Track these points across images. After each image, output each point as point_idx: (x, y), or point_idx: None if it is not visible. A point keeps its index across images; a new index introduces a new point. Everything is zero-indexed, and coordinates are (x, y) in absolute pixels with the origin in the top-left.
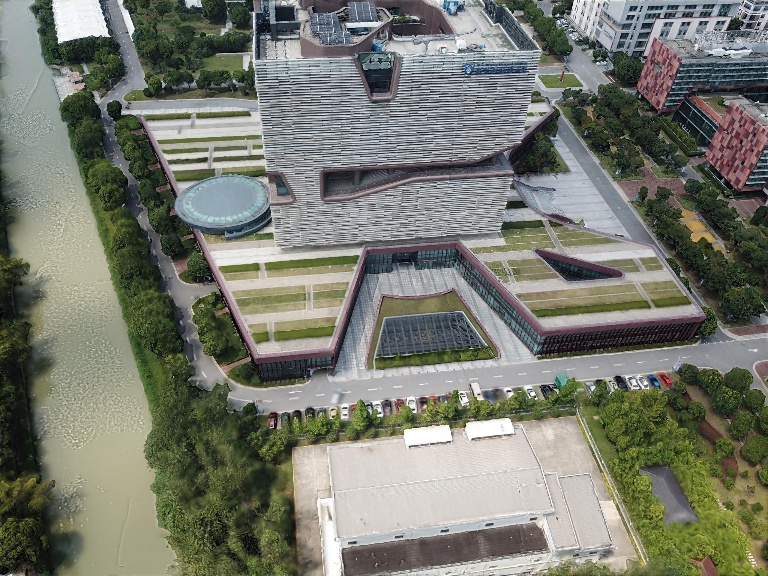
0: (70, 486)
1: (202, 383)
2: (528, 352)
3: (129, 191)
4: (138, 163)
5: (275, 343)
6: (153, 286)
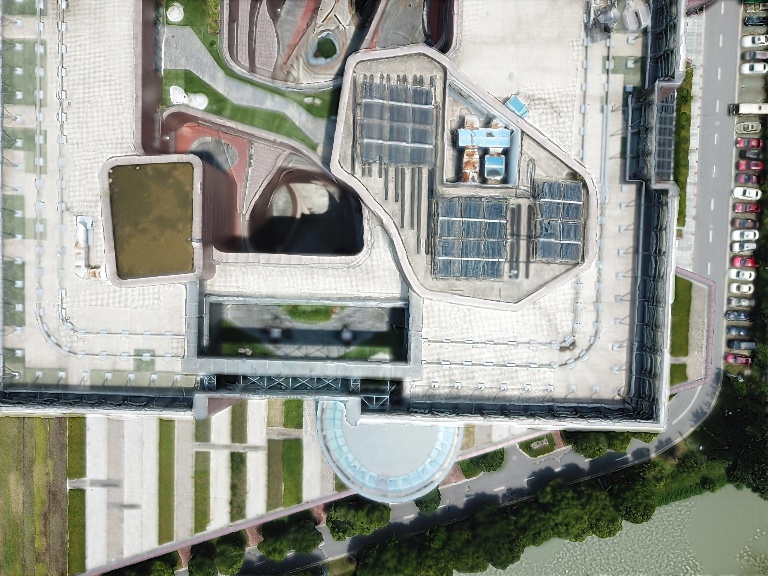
0: (760, 567)
1: (664, 440)
2: (688, 20)
3: (249, 570)
4: (228, 570)
5: (689, 356)
6: (535, 516)
